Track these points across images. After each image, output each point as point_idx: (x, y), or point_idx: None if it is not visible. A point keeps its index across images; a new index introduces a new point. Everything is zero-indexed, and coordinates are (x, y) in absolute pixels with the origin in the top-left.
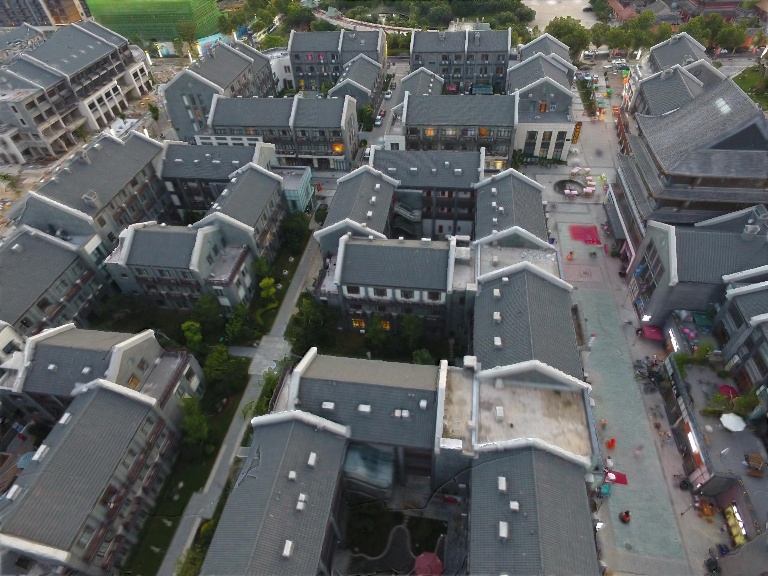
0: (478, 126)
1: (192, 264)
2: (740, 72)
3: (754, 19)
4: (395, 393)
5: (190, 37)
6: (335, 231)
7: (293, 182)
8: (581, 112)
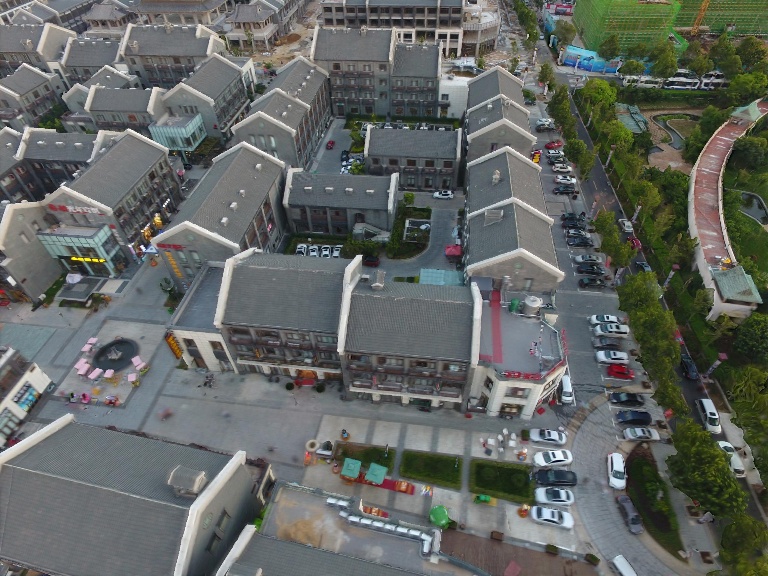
0: None
1: None
2: None
3: None
4: None
5: None
6: None
7: None
8: (359, 434)
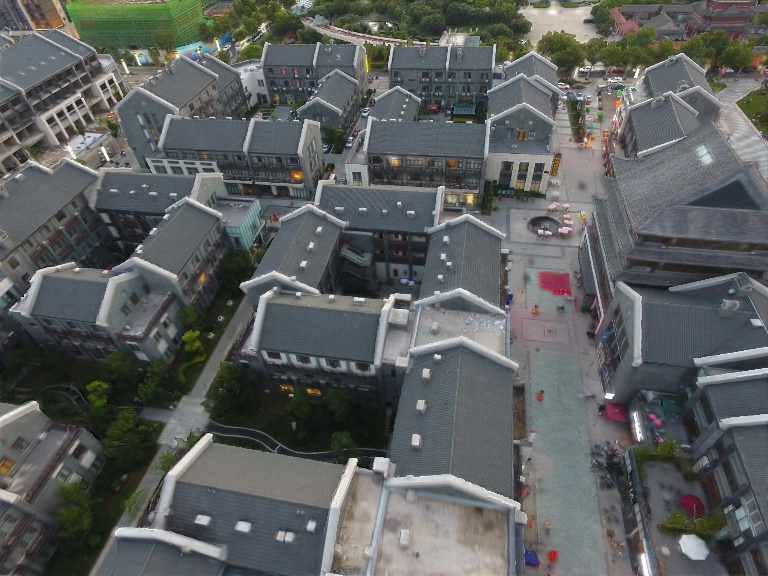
0: (445, 157)
1: (99, 319)
2: (745, 95)
3: (764, 36)
4: (282, 508)
5: (168, 45)
6: (262, 284)
7: (239, 216)
8: (568, 137)
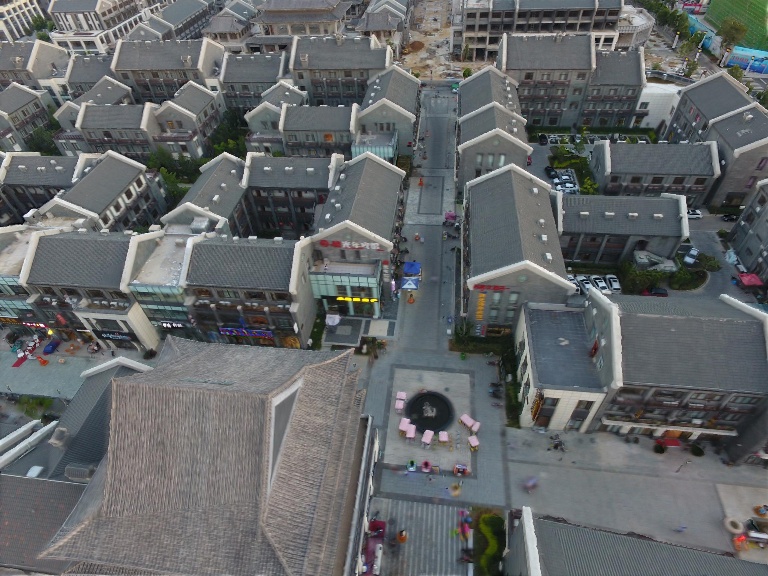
0: None
1: None
2: None
3: None
4: None
5: (729, 39)
6: None
7: None
8: None
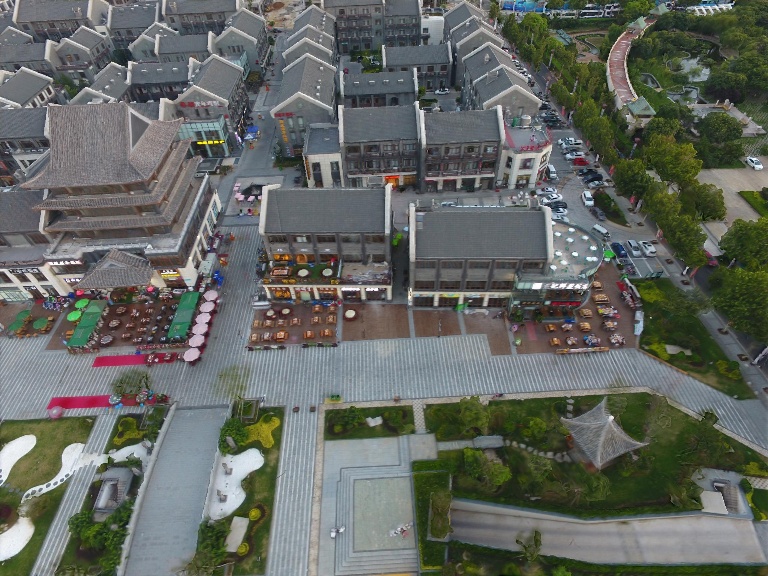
0: None
1: None
2: None
3: None
4: None
5: None
6: None
7: None
8: None
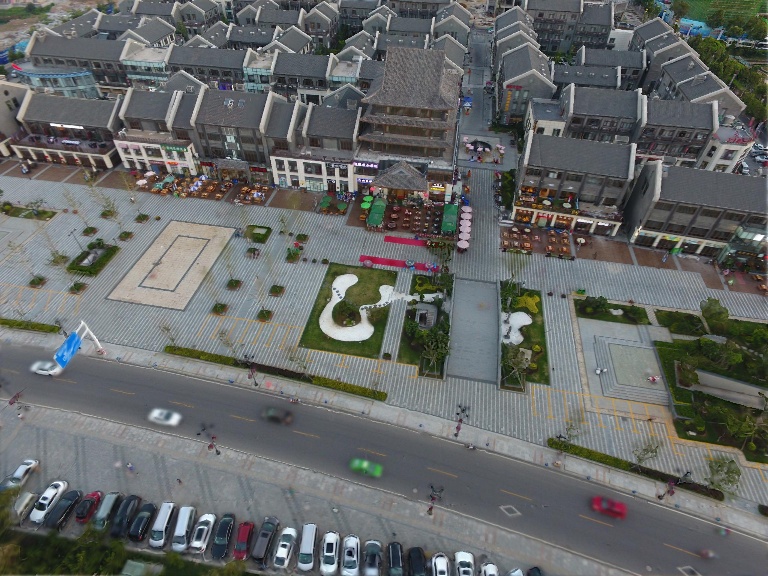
0: None
1: (364, 21)
2: None
3: None
4: None
5: (678, 13)
6: None
7: None
8: None
